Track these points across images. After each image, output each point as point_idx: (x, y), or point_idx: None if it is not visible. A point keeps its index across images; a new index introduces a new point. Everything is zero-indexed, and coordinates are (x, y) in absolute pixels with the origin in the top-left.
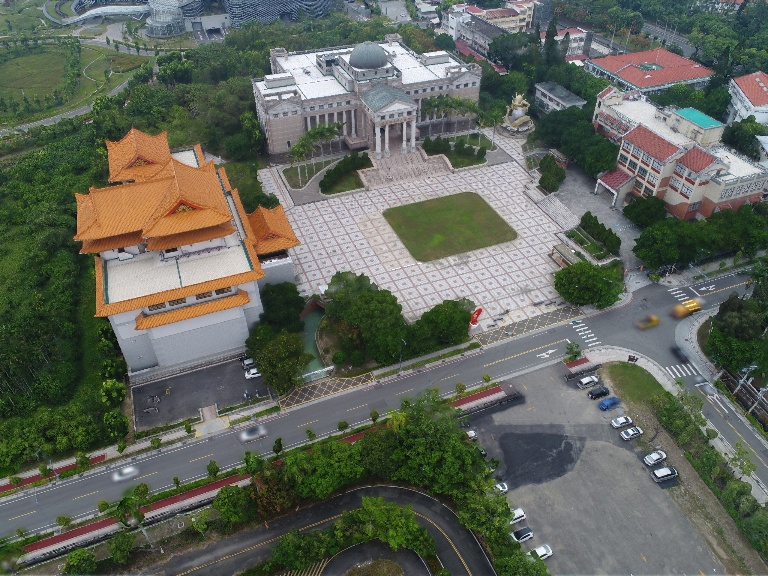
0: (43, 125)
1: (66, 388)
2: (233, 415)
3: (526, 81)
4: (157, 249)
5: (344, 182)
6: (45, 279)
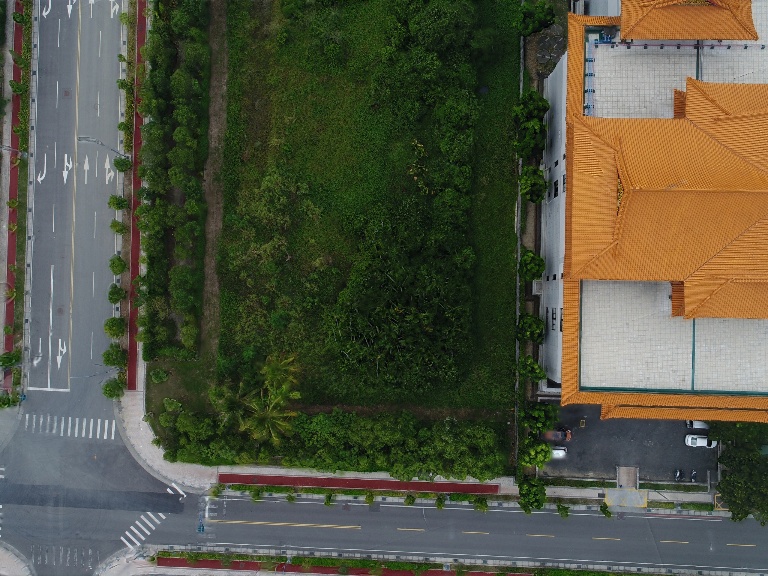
0: None
1: (462, 375)
2: (654, 493)
3: None
4: None
5: None
6: (428, 107)
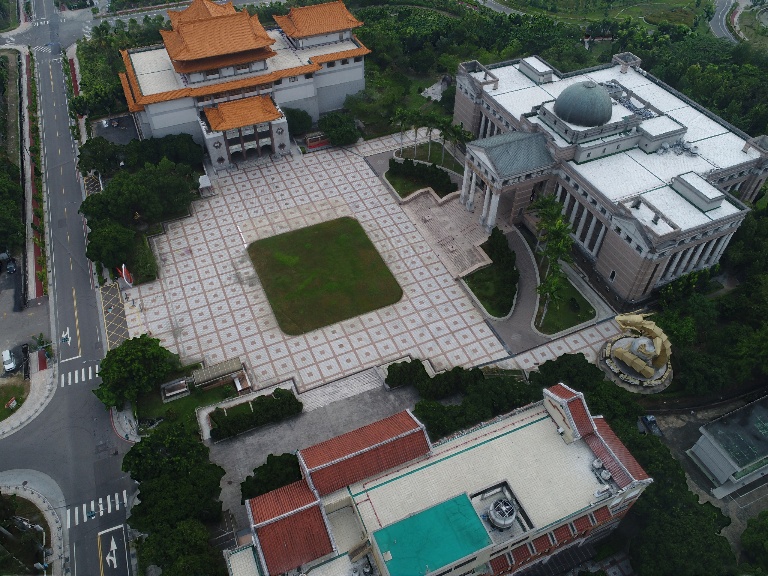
0: (491, 9)
1: None
2: None
3: None
4: (166, 48)
5: (411, 183)
6: None
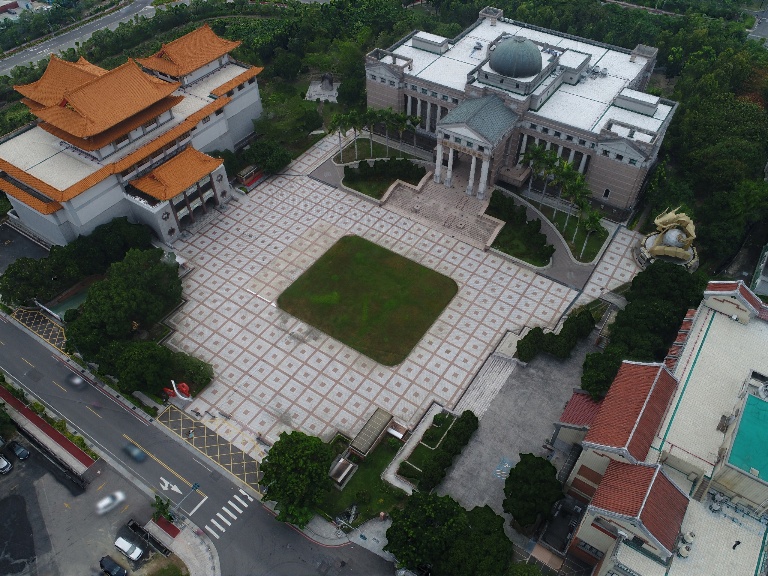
0: None
1: None
2: None
3: (760, 205)
4: (45, 129)
5: (374, 183)
6: None
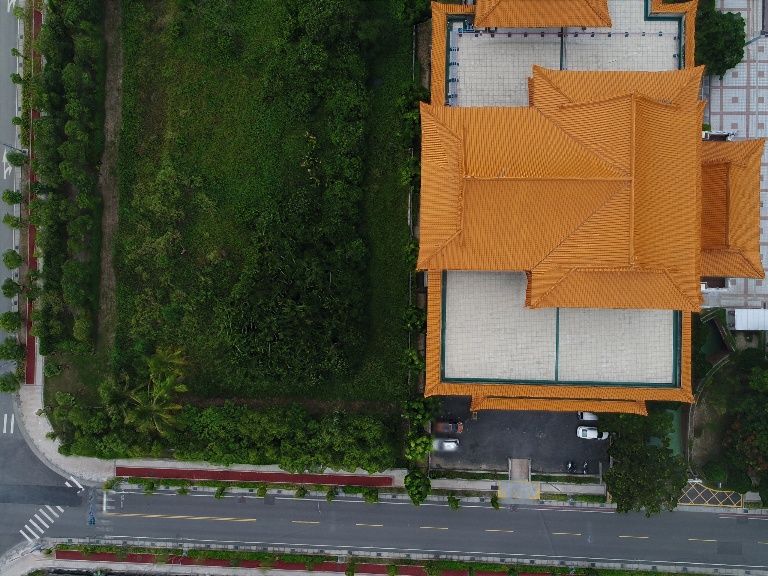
0: None
1: (353, 368)
2: (547, 485)
3: None
4: None
5: None
6: (320, 99)
